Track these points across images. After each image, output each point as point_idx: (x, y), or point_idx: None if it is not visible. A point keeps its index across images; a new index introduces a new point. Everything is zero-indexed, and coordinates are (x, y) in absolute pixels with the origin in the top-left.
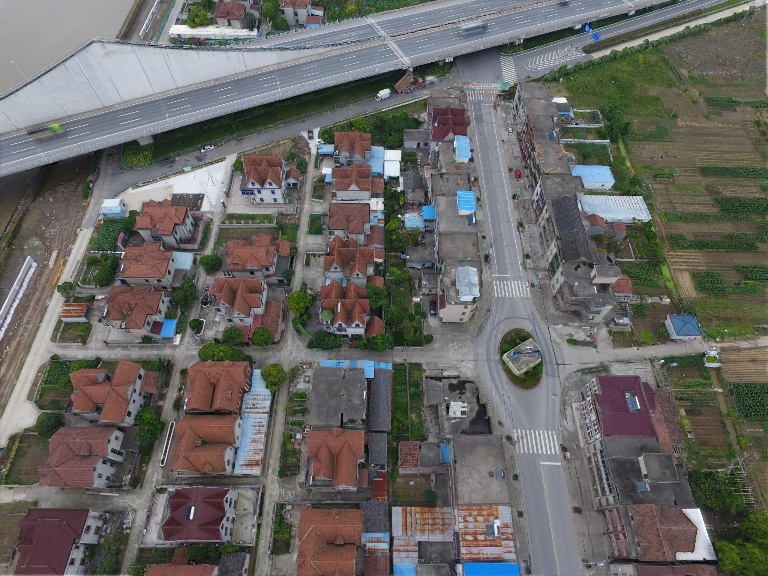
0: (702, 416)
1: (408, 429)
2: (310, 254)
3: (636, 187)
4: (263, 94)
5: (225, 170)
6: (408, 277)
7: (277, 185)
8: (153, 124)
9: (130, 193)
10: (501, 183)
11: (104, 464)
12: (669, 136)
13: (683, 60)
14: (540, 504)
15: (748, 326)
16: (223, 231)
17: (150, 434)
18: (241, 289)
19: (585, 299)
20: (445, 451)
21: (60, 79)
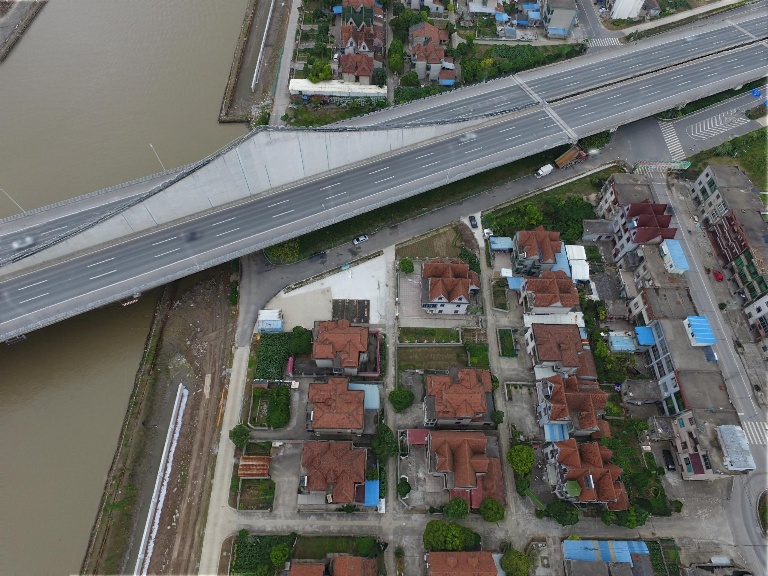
0: None
1: None
2: (510, 384)
3: None
4: (425, 177)
5: (386, 268)
6: (646, 427)
7: (467, 300)
8: (310, 217)
9: (283, 298)
10: (701, 288)
11: None
12: None
13: None
14: None
15: None
16: (401, 351)
17: None
18: (467, 453)
19: None
20: None
21: (215, 172)
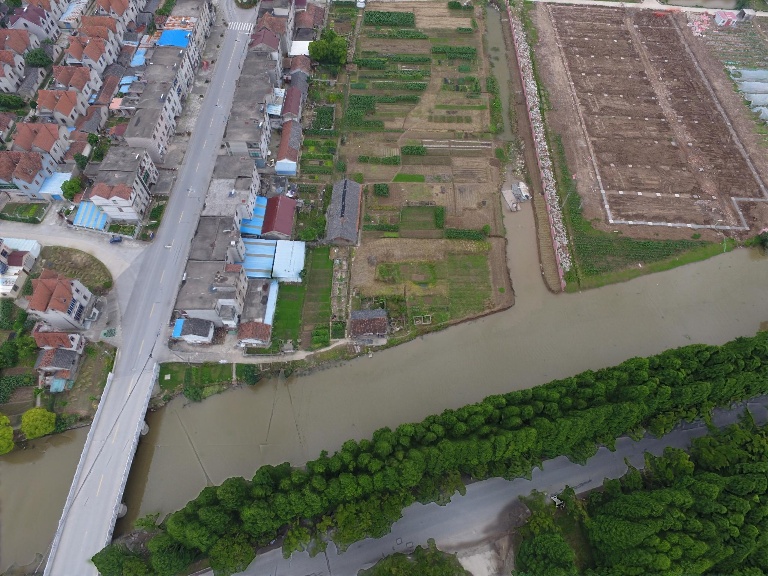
0: (343, 23)
1: None
2: None
3: None
4: None
5: None
6: None
7: None
8: None
9: None
10: None
11: None
12: None
13: None
14: (231, 45)
15: None
16: None
17: (14, 3)
18: None
19: None
20: None
21: None
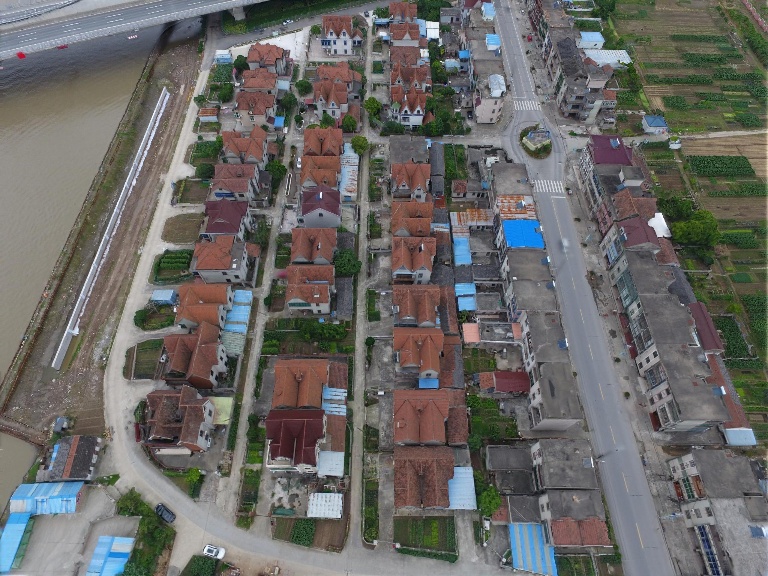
0: (666, 174)
1: (457, 177)
2: (376, 84)
3: None
4: None
5: (303, 36)
6: (452, 90)
7: (349, 36)
8: None
9: (233, 49)
10: (517, 44)
11: (251, 186)
12: (648, 16)
13: None
14: (551, 217)
15: (703, 127)
16: (308, 72)
17: (279, 172)
18: (334, 89)
19: (582, 100)
20: (484, 185)
21: None
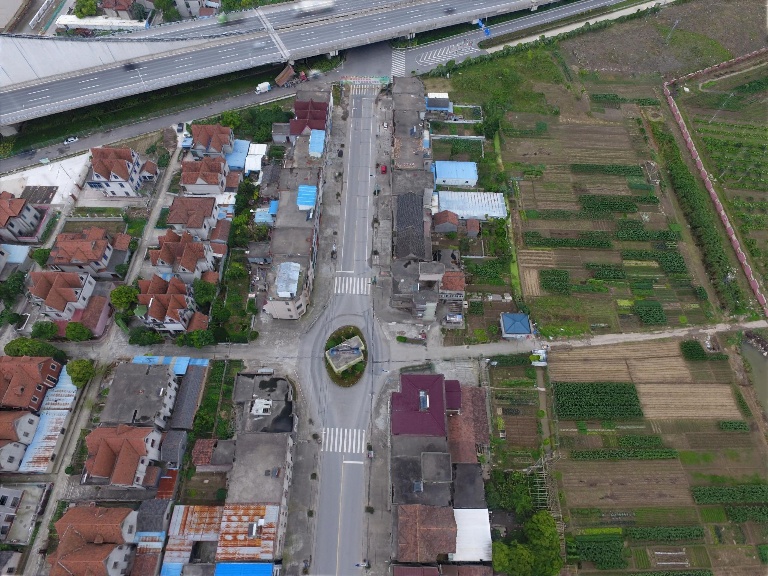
0: (519, 415)
1: (213, 427)
2: (152, 248)
3: (502, 184)
4: (129, 86)
5: (85, 163)
6: (238, 272)
7: (123, 178)
8: (7, 115)
9: None
10: (365, 178)
11: None
12: (547, 133)
13: (576, 56)
14: (333, 503)
15: (585, 325)
16: (69, 224)
17: None
18: (55, 283)
19: None
20: None
21: None
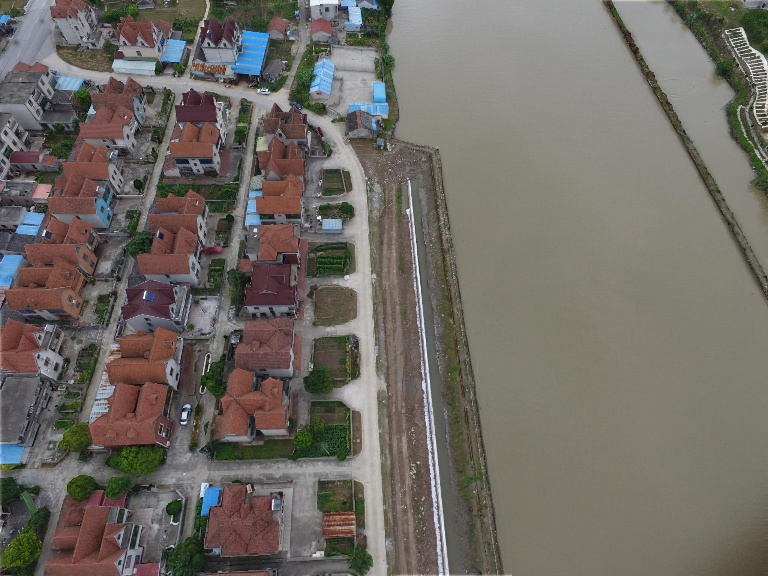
0: None
1: None
2: None
3: None
4: None
5: None
6: None
7: None
8: None
9: None
10: None
11: None
12: None
13: None
14: None
15: None
16: None
17: None
18: (77, 545)
19: None
20: None
21: None
